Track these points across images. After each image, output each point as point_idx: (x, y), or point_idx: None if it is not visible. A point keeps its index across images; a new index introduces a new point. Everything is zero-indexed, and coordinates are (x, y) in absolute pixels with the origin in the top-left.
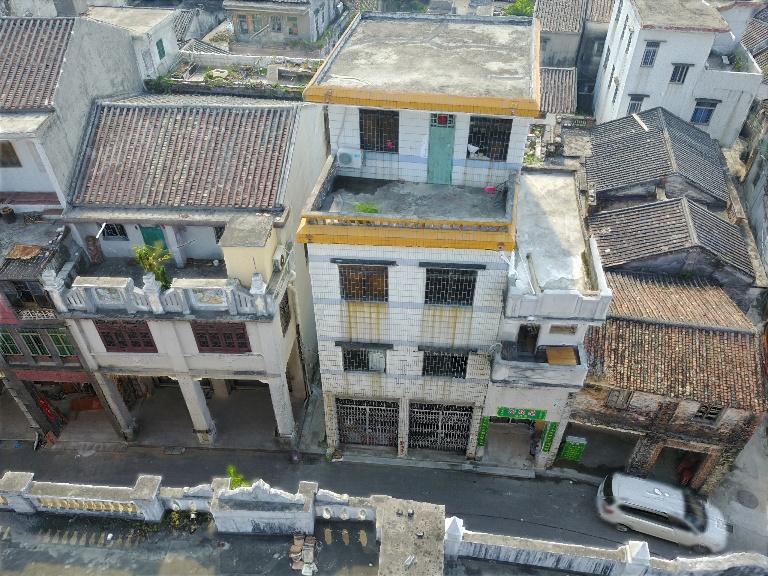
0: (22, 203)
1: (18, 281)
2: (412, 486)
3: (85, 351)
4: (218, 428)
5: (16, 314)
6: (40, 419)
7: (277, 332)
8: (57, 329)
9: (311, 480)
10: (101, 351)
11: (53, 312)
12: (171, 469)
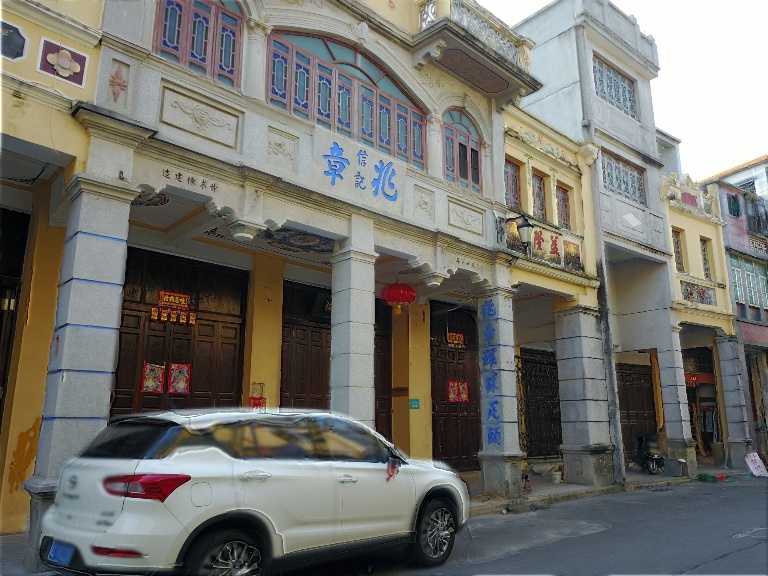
0: None
1: (754, 203)
2: None
3: None
4: None
5: (749, 242)
6: (750, 424)
7: None
8: (762, 270)
9: None
10: None
11: (764, 246)
12: None
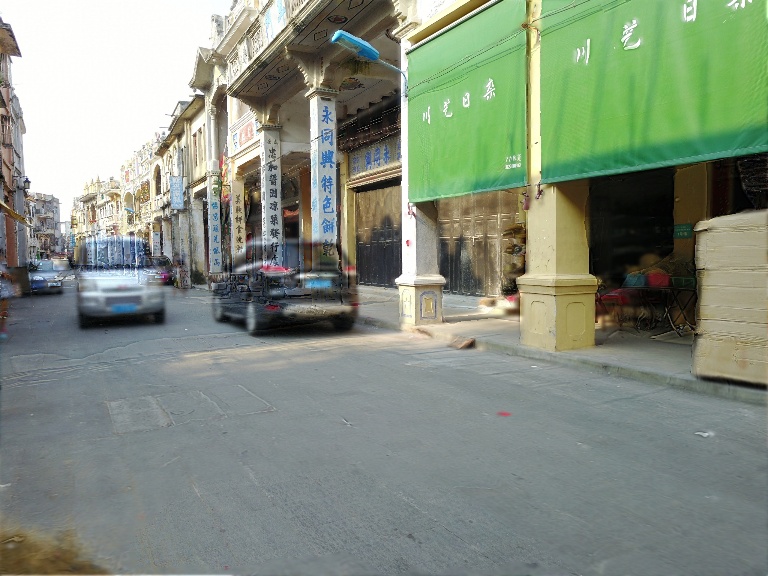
0: None
1: None
2: None
3: None
4: None
5: None
6: None
7: None
8: None
9: None
10: None
11: None
12: None
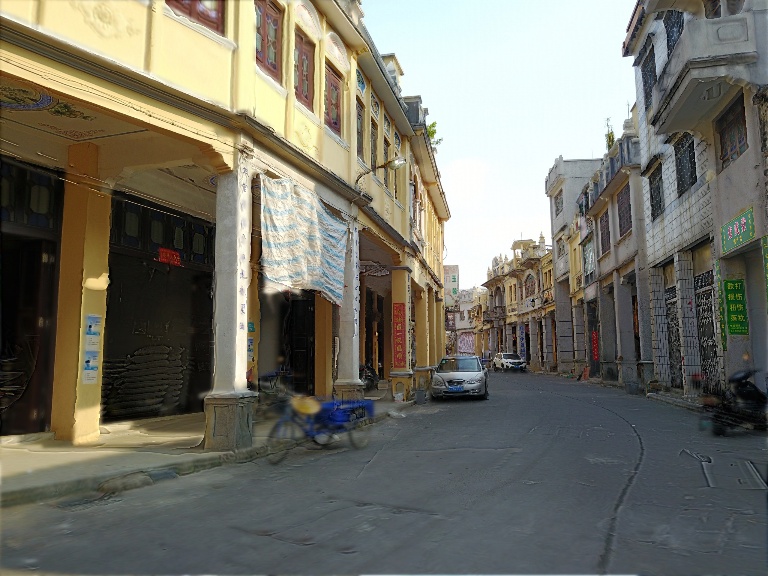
0: None
1: None
2: (642, 407)
3: None
4: None
5: None
6: (588, 352)
7: None
8: None
9: (610, 396)
10: None
11: None
12: None
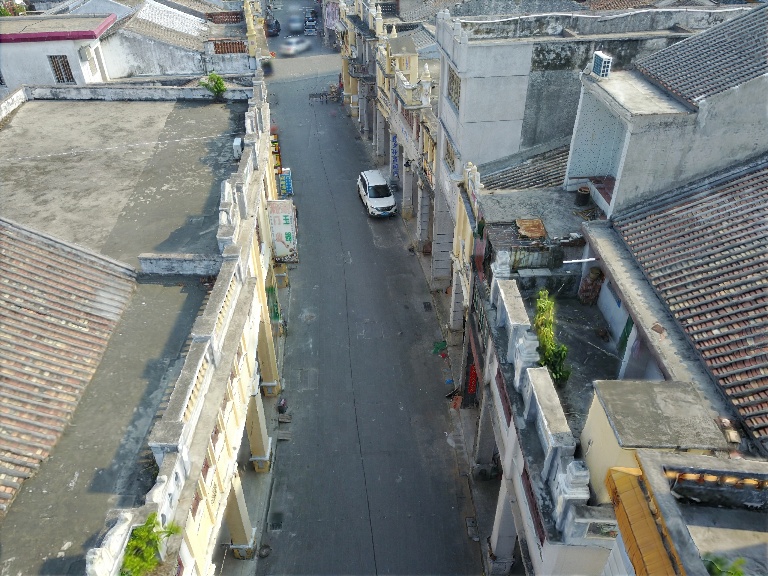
0: (604, 195)
1: None
2: None
3: (488, 357)
4: (517, 573)
5: None
6: None
7: (579, 573)
8: None
9: None
10: (495, 371)
11: None
12: (448, 533)
